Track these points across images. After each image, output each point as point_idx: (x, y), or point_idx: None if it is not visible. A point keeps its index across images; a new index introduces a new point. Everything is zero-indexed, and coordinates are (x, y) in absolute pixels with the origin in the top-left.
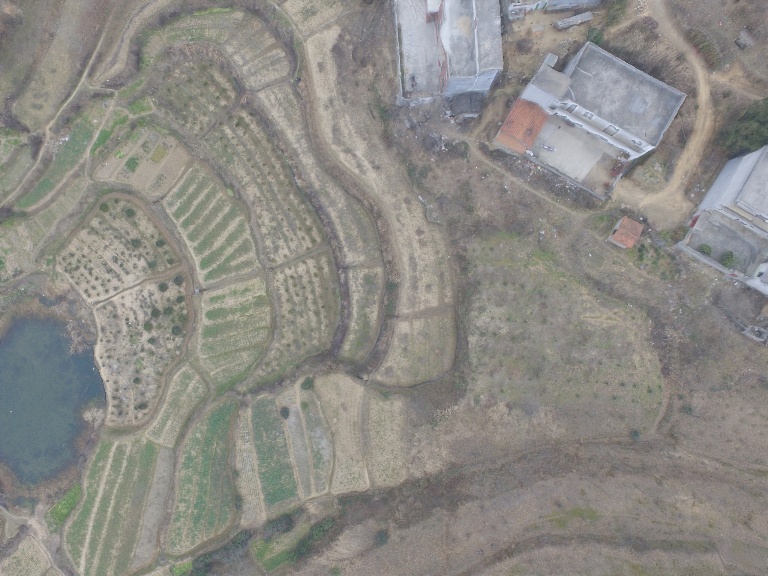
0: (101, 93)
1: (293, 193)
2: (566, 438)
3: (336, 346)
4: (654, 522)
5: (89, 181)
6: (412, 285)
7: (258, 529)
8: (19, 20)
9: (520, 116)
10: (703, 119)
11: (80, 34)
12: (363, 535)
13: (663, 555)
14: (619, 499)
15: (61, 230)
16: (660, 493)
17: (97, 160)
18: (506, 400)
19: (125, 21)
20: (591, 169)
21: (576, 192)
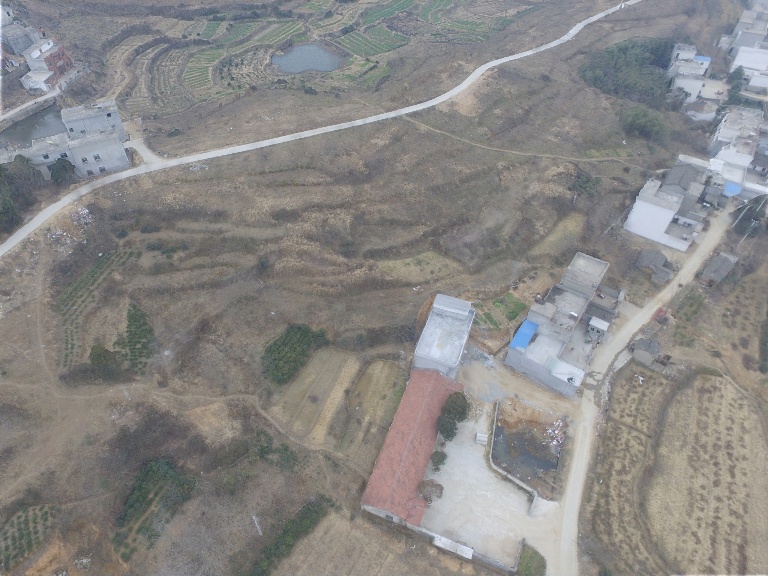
0: None
1: None
2: None
3: (169, 46)
4: None
5: None
6: None
7: None
8: None
9: None
10: None
11: None
12: None
13: None
14: None
15: None
16: None
17: None
18: (117, 24)
19: None
20: None
21: None
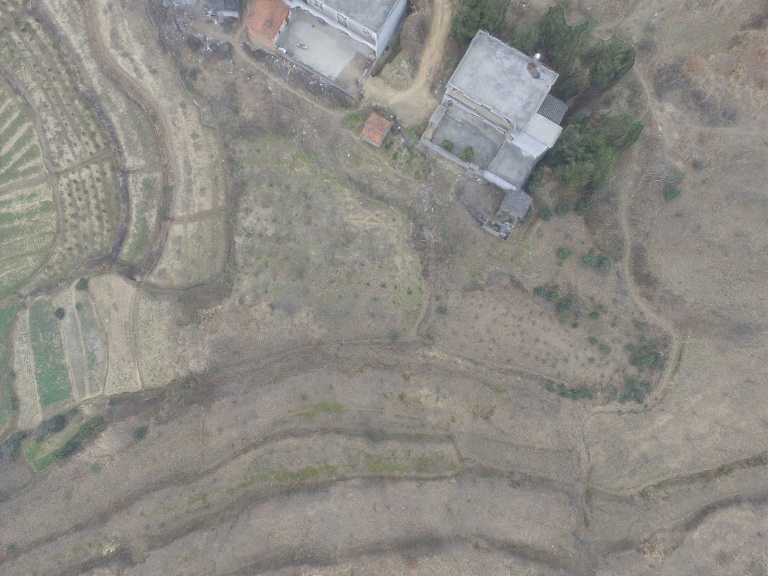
0: None
1: (78, 99)
2: (328, 339)
3: (114, 249)
4: (398, 416)
5: None
6: (186, 188)
7: (34, 430)
8: None
9: (260, 8)
10: (441, 14)
11: None
12: (125, 432)
13: (399, 445)
14: (365, 393)
15: None
16: (406, 388)
17: None
18: (271, 300)
19: None
20: (344, 68)
21: (329, 90)
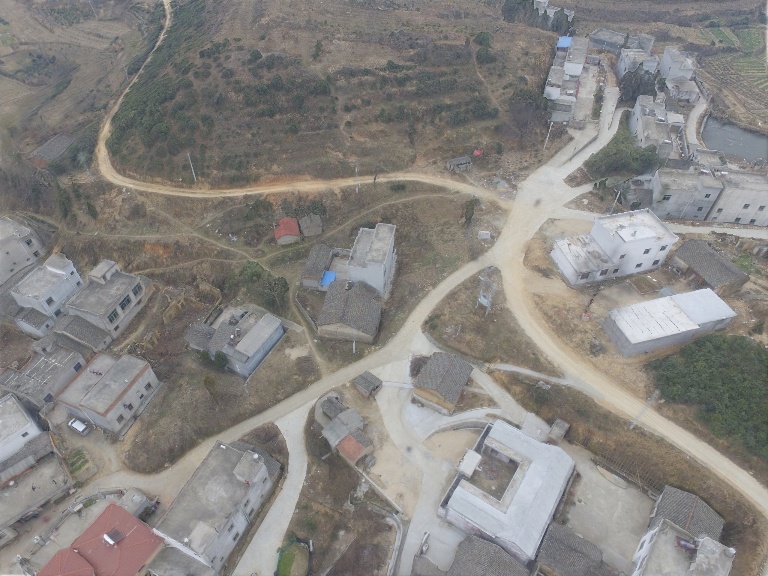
0: None
1: None
2: None
3: None
4: None
5: None
6: None
7: None
8: None
9: None
10: None
11: None
12: None
13: None
14: None
15: None
16: (577, 3)
17: None
18: None
19: None
20: None
21: None
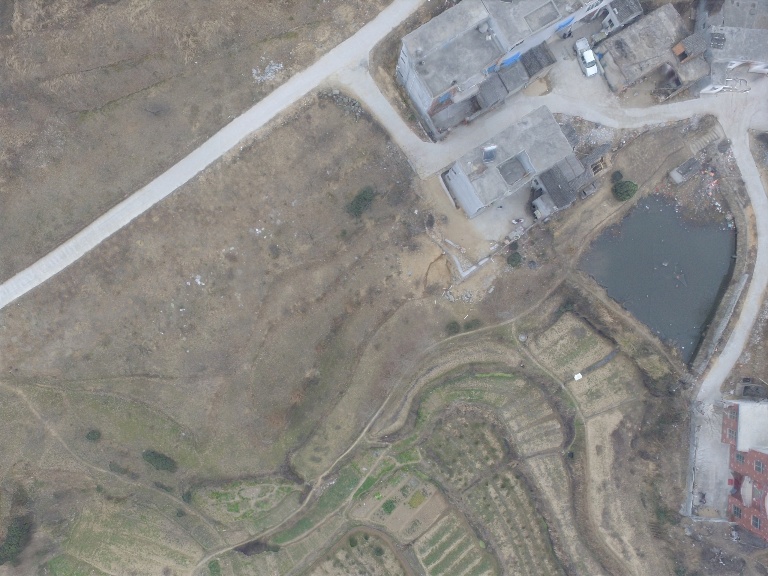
0: (377, 446)
1: (548, 558)
2: None
3: None
4: None
5: (345, 519)
6: None
7: None
8: (316, 381)
9: None
10: None
11: (370, 395)
12: None
13: None
14: None
15: (308, 560)
16: None
17: (357, 501)
18: None
19: (411, 380)
20: None
21: None
